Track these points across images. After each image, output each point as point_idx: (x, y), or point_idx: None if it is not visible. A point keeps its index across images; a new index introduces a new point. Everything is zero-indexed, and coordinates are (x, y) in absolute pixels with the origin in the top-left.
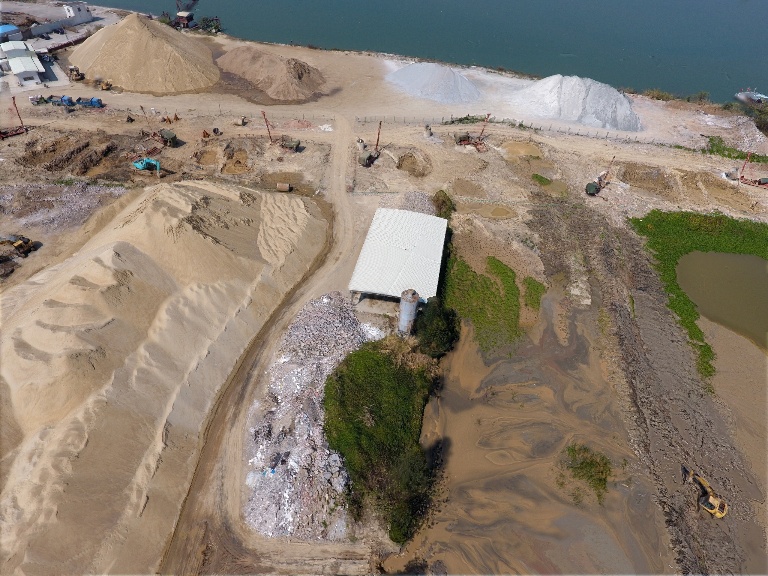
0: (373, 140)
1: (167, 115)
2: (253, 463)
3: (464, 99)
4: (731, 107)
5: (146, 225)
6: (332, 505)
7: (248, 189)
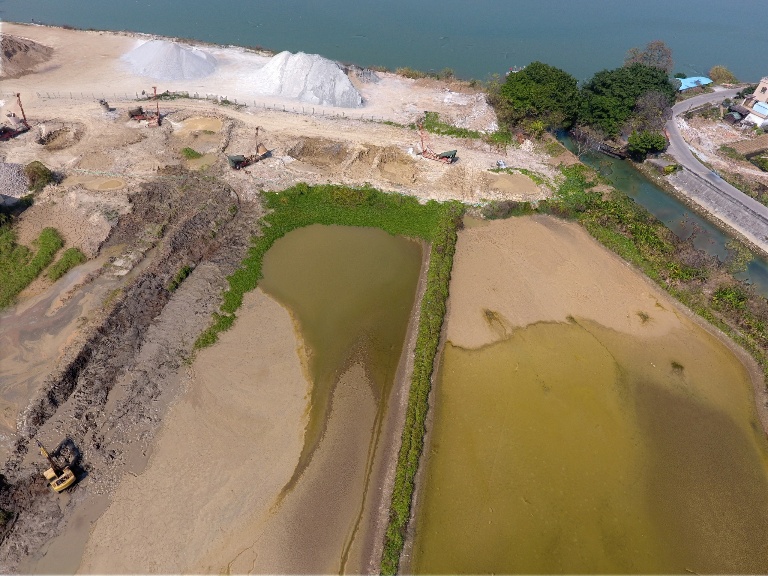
0: (39, 115)
1: None
2: None
3: (187, 77)
4: (475, 84)
5: None
6: None
7: None
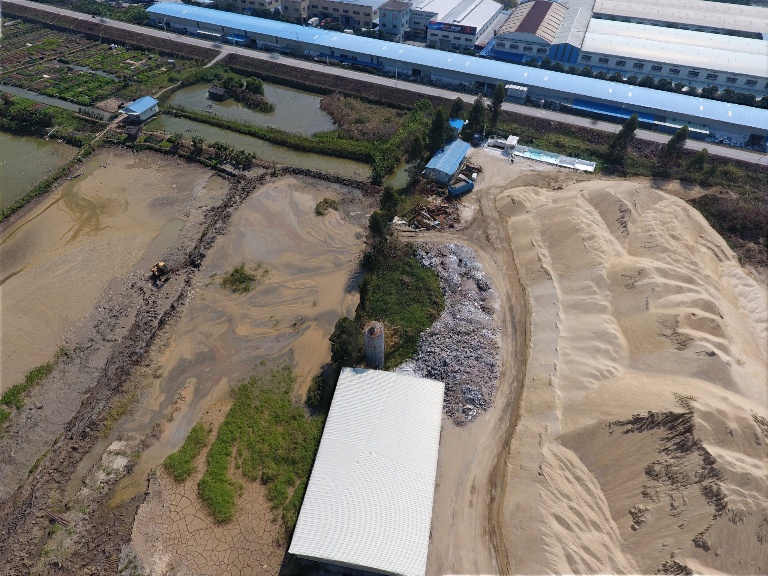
0: None
1: None
2: (482, 273)
3: None
4: None
5: (726, 397)
6: None
7: None
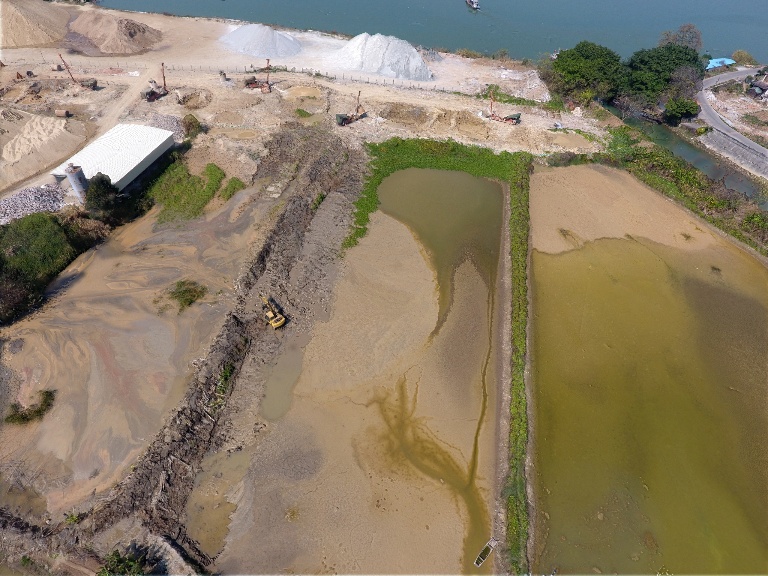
0: (171, 83)
1: None
2: None
3: (280, 55)
4: (527, 63)
5: None
6: None
7: (24, 112)
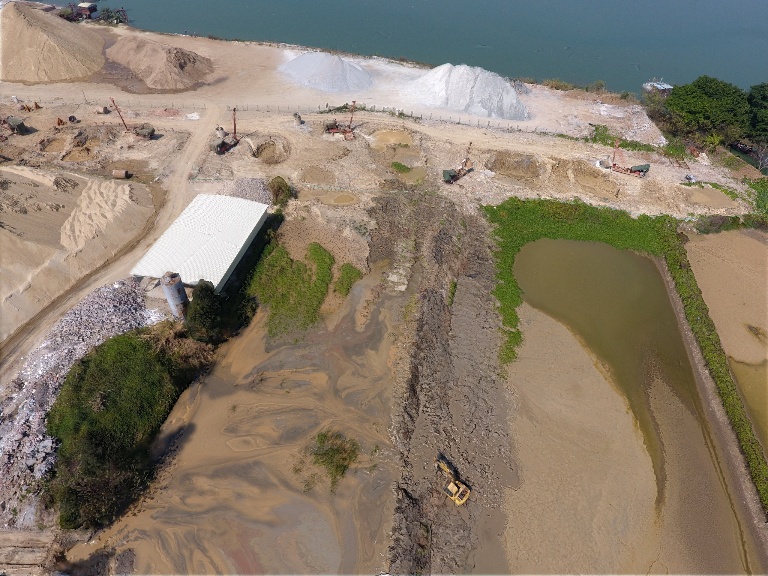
0: (238, 128)
1: (29, 103)
2: None
3: (352, 88)
4: (627, 96)
5: None
6: (24, 492)
7: (76, 175)
